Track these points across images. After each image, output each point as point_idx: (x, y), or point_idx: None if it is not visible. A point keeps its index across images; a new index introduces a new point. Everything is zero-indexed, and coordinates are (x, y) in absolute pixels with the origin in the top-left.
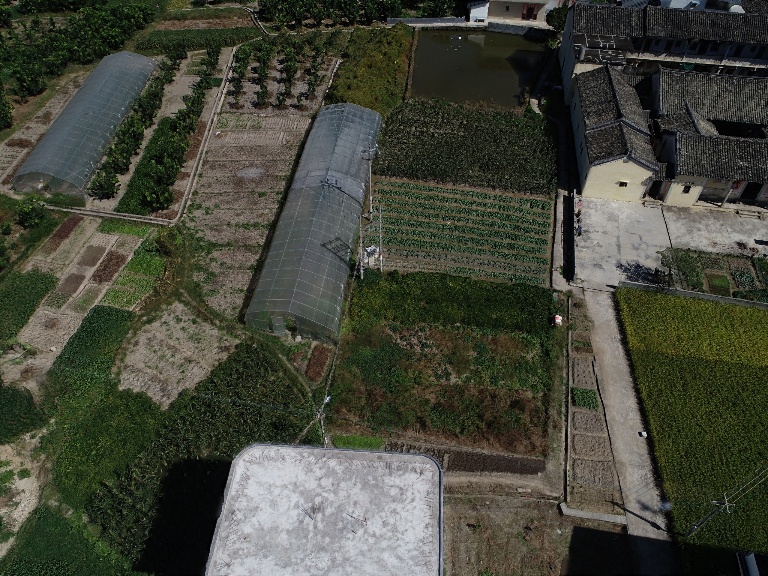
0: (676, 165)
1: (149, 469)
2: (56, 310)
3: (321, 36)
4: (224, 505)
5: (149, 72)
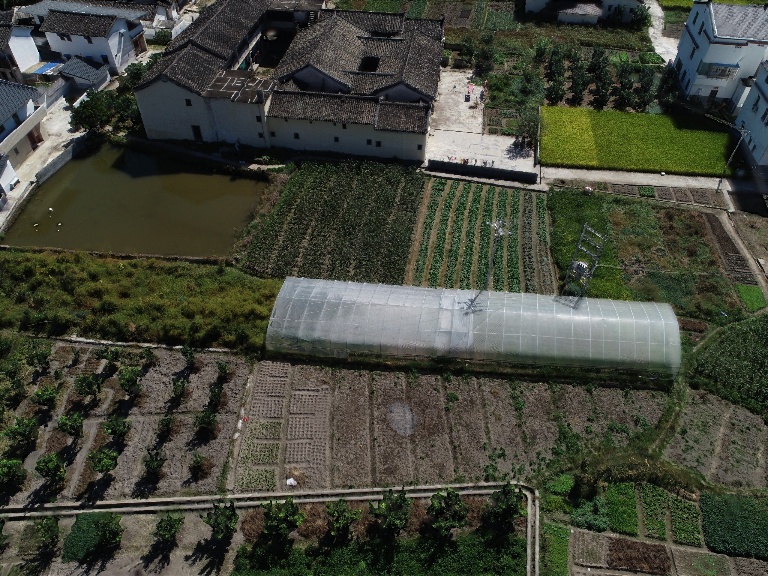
0: (428, 96)
1: None
2: None
3: None
4: None
5: None
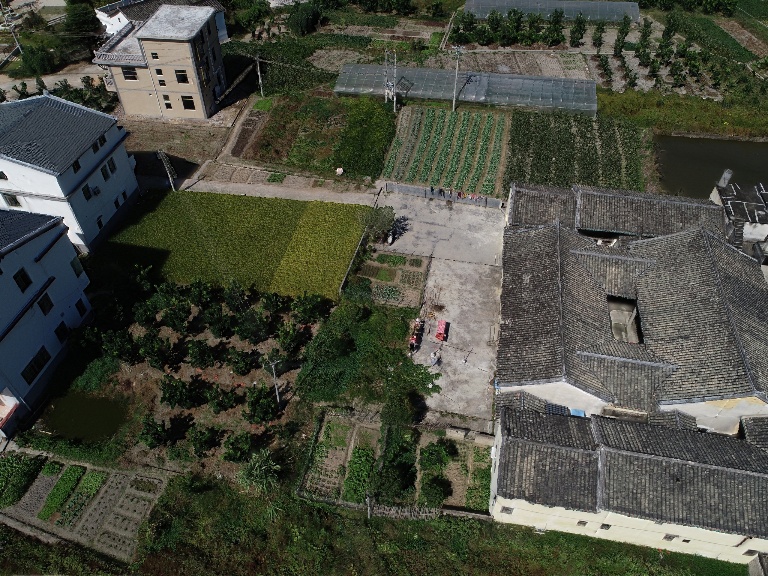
0: None
1: (265, 55)
2: (369, 31)
3: (759, 86)
4: (192, 6)
5: (620, 19)
